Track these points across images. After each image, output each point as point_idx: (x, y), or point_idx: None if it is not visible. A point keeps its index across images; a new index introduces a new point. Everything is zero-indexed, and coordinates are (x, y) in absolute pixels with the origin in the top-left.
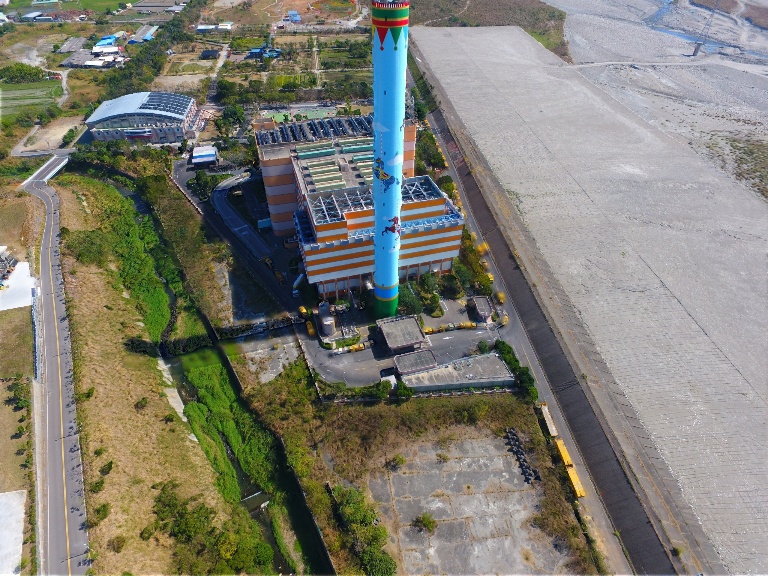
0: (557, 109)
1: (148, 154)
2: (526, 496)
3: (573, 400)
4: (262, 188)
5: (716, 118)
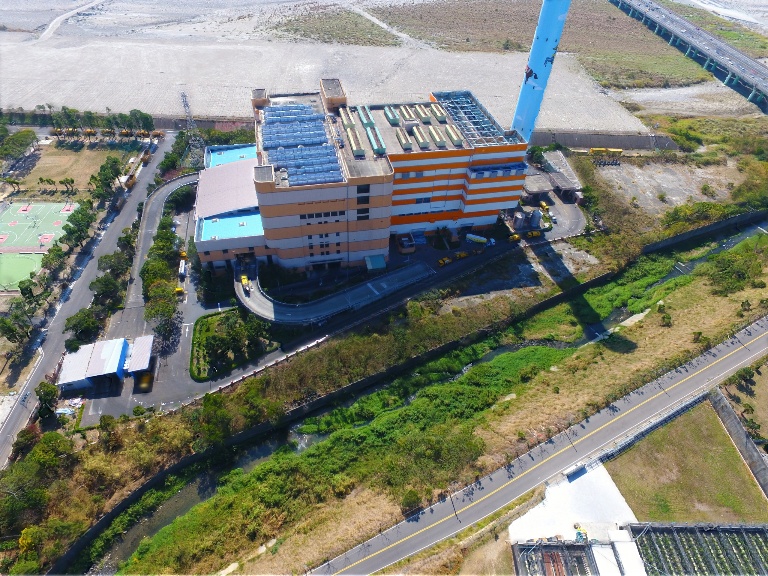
0: (164, 65)
1: (45, 470)
2: (628, 167)
3: (564, 139)
4: (282, 269)
5: (232, 22)
